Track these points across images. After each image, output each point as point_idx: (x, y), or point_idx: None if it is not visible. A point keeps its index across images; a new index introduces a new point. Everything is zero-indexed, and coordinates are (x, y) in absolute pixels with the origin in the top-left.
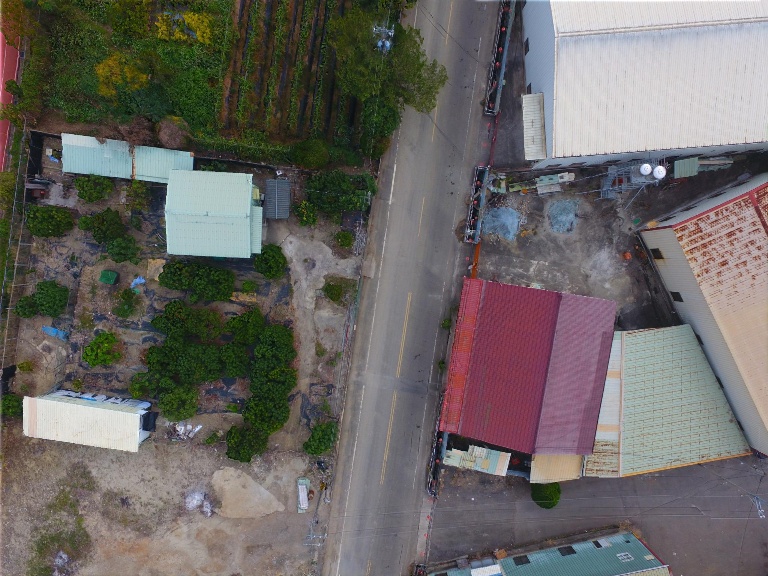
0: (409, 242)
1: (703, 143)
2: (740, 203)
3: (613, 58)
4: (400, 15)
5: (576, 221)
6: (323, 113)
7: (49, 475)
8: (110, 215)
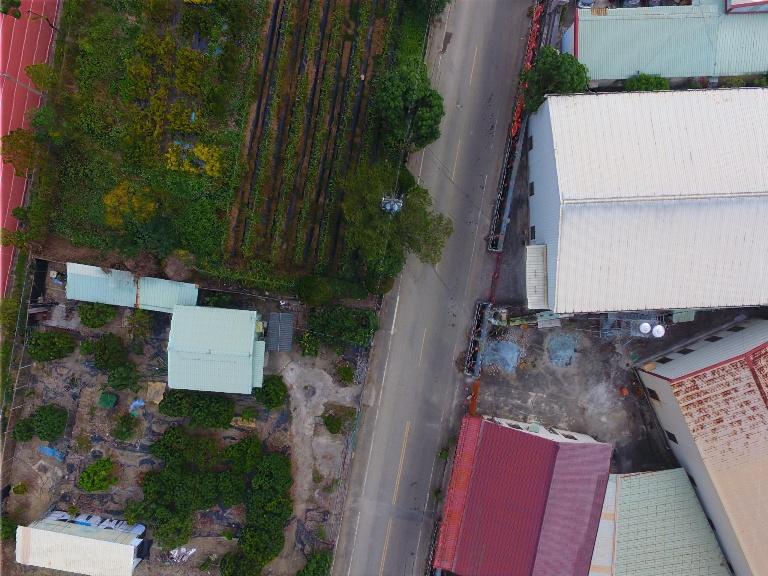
0: (409, 372)
1: (702, 304)
2: (736, 364)
3: (616, 224)
4: (408, 154)
5: (575, 355)
6: (329, 246)
7: None
8: (112, 342)
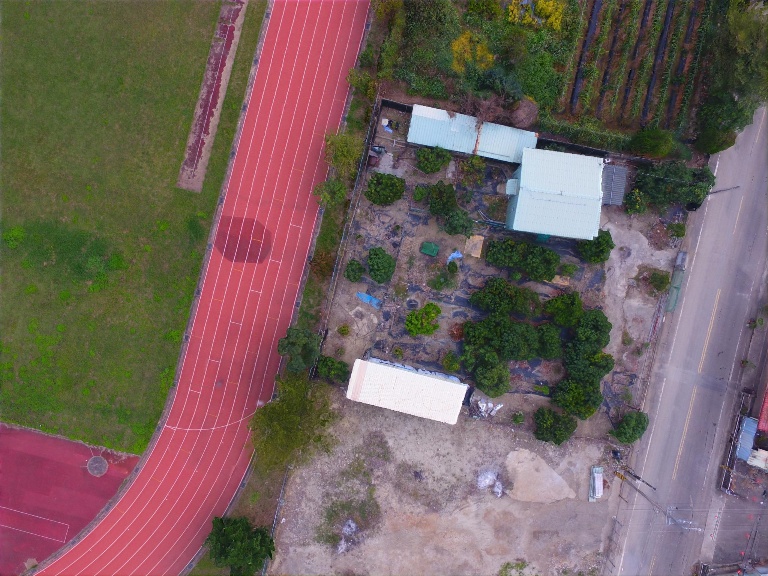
0: (724, 239)
1: None
2: None
3: None
4: None
5: None
6: None
7: (346, 442)
8: (447, 188)
